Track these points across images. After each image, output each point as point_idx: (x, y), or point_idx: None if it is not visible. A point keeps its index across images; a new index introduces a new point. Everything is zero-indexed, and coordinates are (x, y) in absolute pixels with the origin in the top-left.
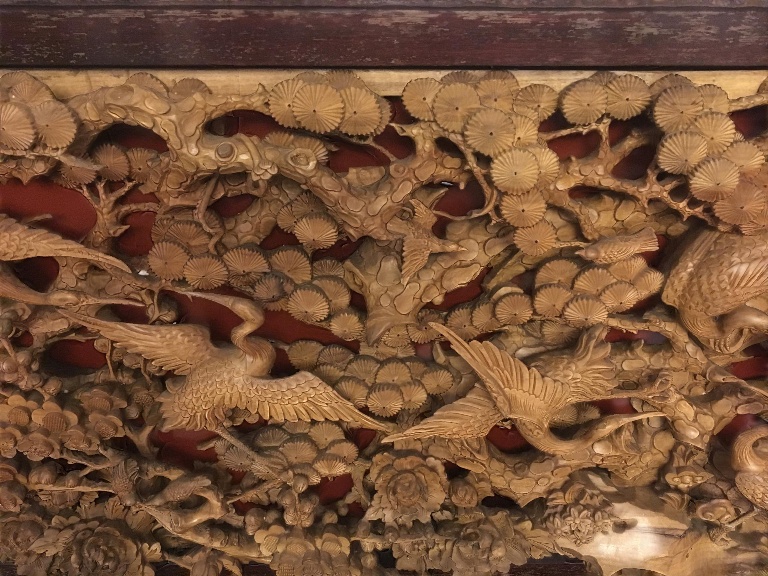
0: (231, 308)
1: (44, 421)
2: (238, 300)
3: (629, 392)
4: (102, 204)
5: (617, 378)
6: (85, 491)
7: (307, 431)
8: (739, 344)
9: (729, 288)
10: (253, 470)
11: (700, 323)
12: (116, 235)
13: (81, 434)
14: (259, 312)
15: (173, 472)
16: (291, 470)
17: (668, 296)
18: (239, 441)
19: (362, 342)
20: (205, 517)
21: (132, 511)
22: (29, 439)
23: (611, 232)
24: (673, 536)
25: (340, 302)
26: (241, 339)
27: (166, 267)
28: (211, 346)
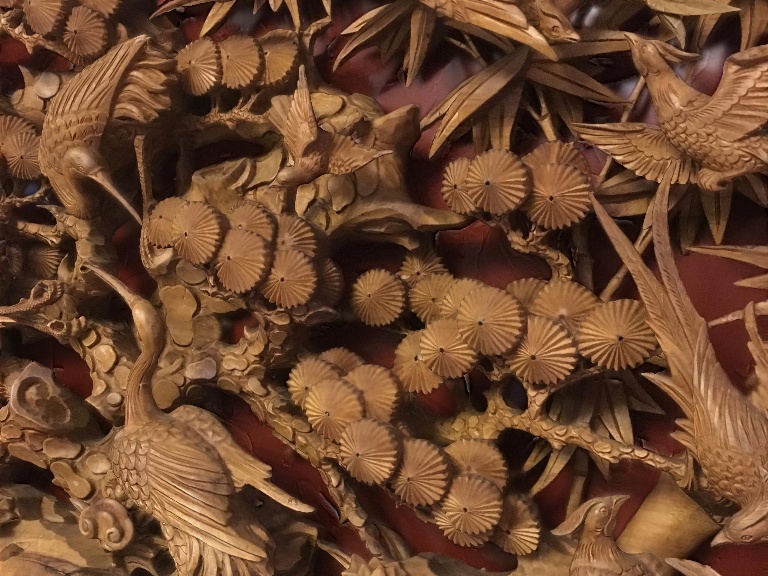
0: None
1: None
2: None
3: (9, 306)
4: None
5: (49, 317)
6: None
7: None
8: (167, 253)
9: (51, 119)
10: None
11: (66, 193)
12: None
13: None
14: None
15: None
16: None
17: (40, 162)
18: None
19: None
20: None
21: None
22: None
23: (36, 114)
24: (56, 571)
25: None
26: None
27: None
28: None
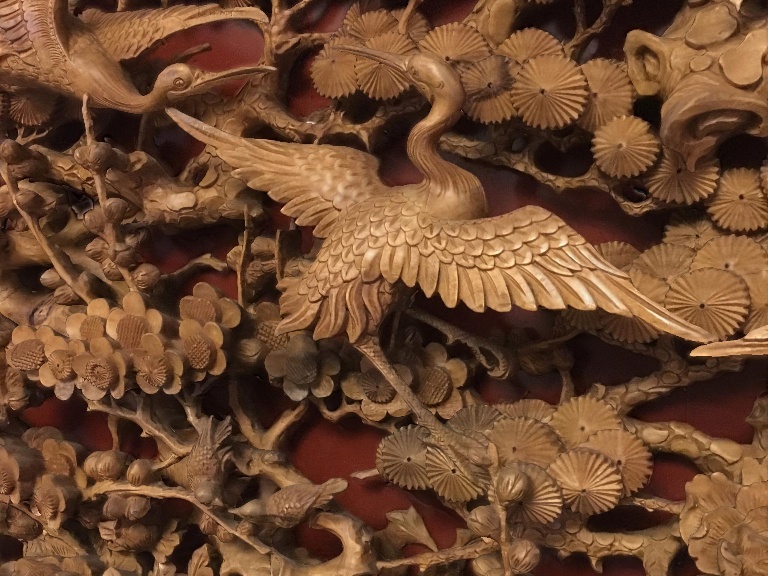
0: (408, 70)
1: (119, 328)
2: (420, 53)
3: None
4: (273, 21)
5: None
6: (153, 495)
7: (547, 421)
8: None
9: None
10: (428, 469)
11: None
12: (279, 52)
13: (159, 347)
14: (454, 74)
15: (293, 477)
16: (494, 443)
17: None
18: (404, 383)
19: (667, 236)
20: (329, 575)
21: (220, 573)
22: (90, 351)
23: None
24: None
25: (614, 100)
26: (422, 142)
27: (332, 69)
28: (377, 181)
